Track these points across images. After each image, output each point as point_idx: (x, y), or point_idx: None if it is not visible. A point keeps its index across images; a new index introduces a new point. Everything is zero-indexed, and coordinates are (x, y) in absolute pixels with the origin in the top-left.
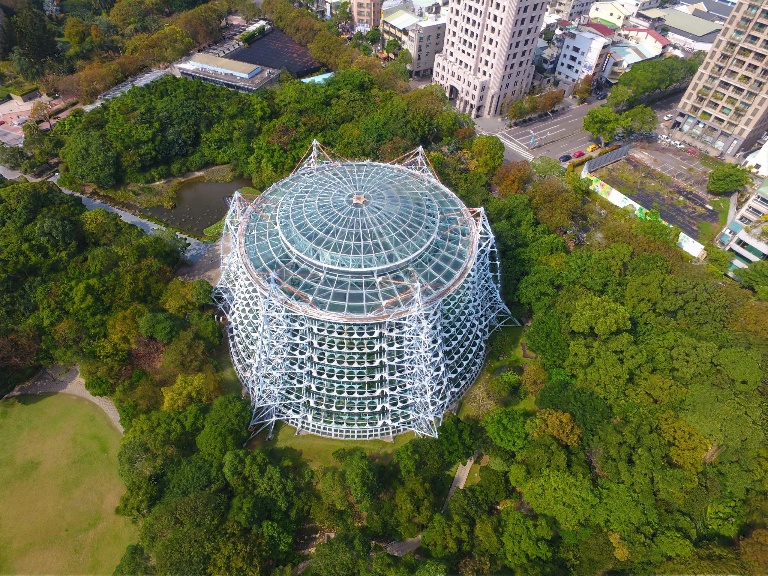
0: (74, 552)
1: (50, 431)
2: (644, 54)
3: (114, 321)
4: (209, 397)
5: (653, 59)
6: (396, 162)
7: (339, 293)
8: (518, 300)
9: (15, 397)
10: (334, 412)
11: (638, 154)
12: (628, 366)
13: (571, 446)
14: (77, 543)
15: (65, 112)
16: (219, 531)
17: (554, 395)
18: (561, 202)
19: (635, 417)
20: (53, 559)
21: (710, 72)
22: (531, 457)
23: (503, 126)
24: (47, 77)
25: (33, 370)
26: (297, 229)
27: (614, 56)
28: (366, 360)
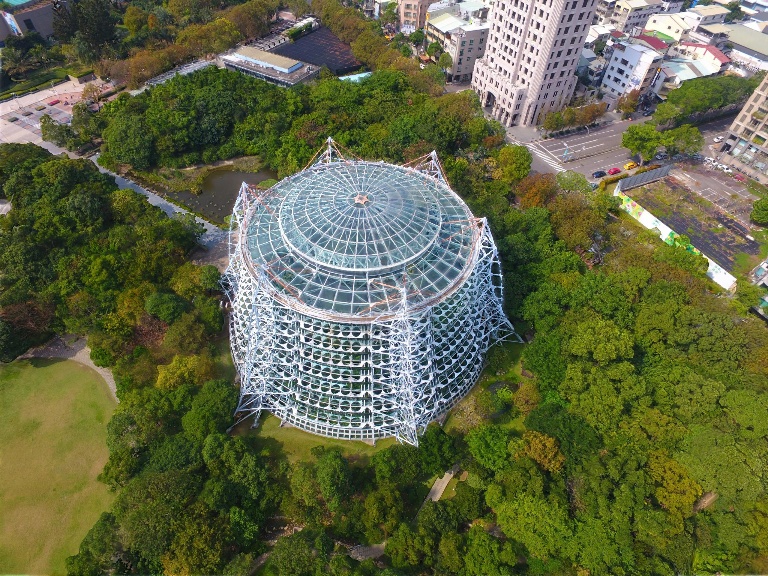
0: (58, 511)
1: (54, 395)
2: (700, 71)
3: (123, 297)
4: (201, 379)
5: (710, 77)
6: None
7: (329, 291)
8: (521, 316)
9: (29, 359)
10: (318, 408)
11: (679, 176)
12: (624, 397)
13: (552, 473)
14: (62, 503)
15: (114, 95)
16: (187, 510)
17: (543, 418)
18: (582, 219)
19: (624, 451)
20: (38, 515)
21: (767, 94)
22: (508, 479)
23: (538, 137)
24: (102, 61)
25: (47, 335)
26: (296, 224)
27: (666, 71)
28: (351, 360)
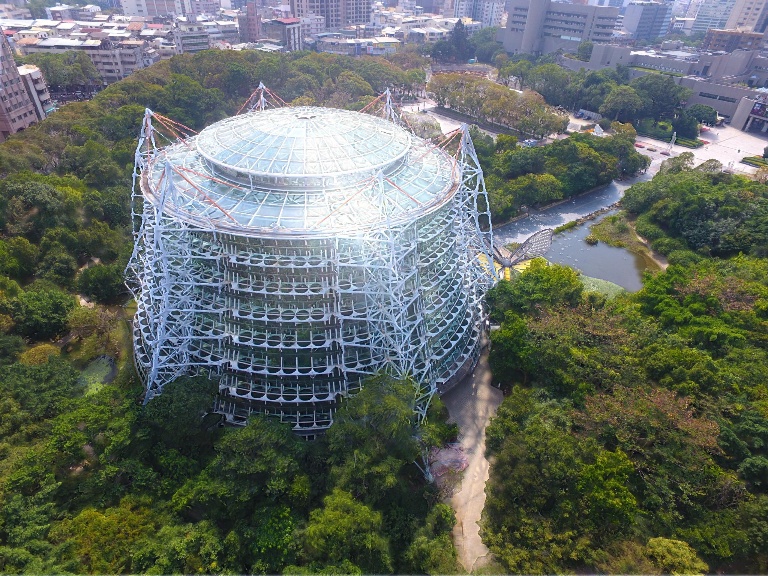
0: None
1: None
2: None
3: None
4: None
5: None
6: (605, 400)
7: None
8: None
9: None
10: None
11: None
12: None
13: None
14: None
15: None
16: None
17: None
18: None
19: None
20: None
21: None
22: None
23: None
24: None
25: None
26: None
27: None
28: None
